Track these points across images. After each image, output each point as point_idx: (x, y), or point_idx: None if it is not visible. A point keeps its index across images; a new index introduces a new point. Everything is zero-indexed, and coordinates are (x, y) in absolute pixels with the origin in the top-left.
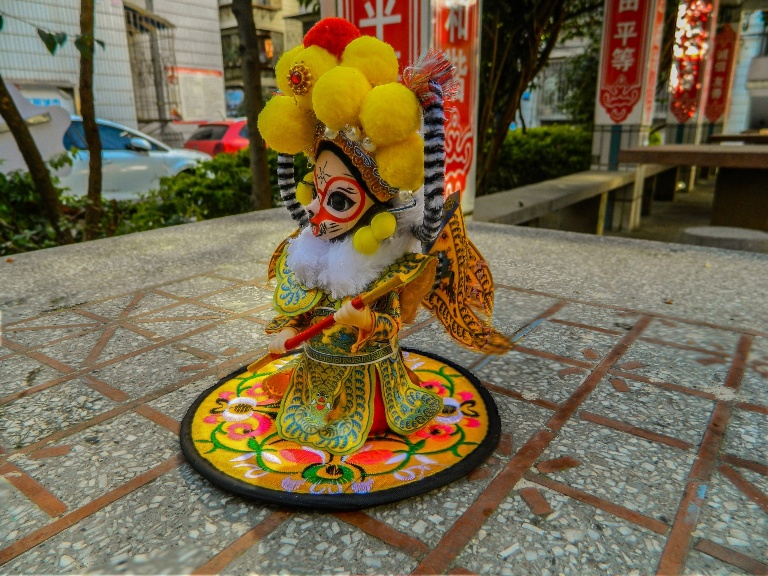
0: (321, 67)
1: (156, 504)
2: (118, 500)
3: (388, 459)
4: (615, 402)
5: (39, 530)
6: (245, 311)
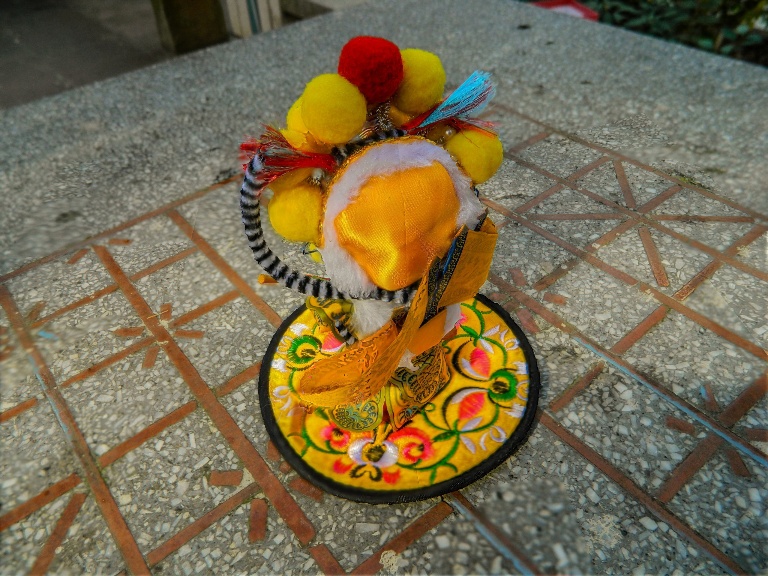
0: None
1: None
2: None
3: None
4: None
5: None
6: (689, 307)
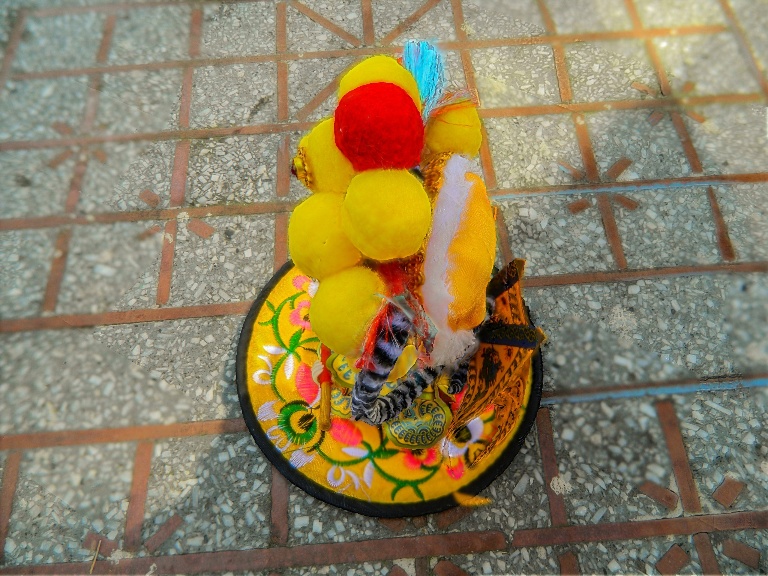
0: (324, 177)
1: (205, 343)
2: (192, 319)
3: (350, 446)
4: (625, 575)
5: (144, 310)
6: (489, 107)
